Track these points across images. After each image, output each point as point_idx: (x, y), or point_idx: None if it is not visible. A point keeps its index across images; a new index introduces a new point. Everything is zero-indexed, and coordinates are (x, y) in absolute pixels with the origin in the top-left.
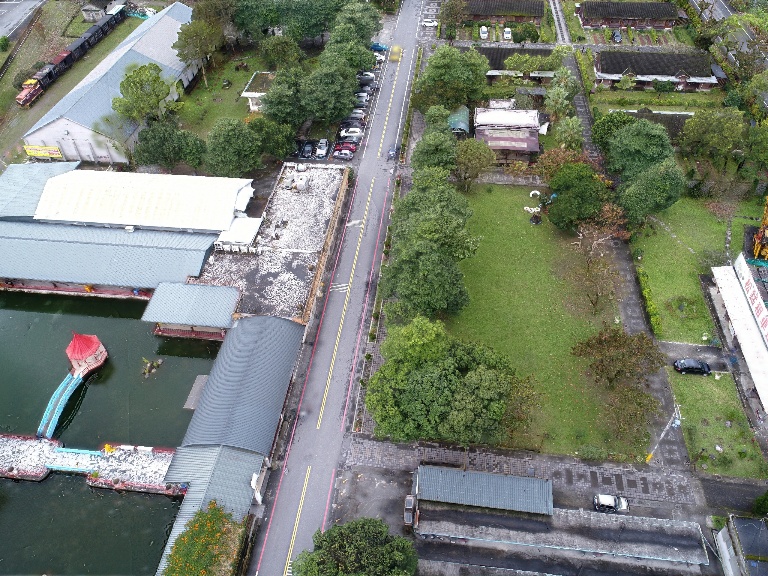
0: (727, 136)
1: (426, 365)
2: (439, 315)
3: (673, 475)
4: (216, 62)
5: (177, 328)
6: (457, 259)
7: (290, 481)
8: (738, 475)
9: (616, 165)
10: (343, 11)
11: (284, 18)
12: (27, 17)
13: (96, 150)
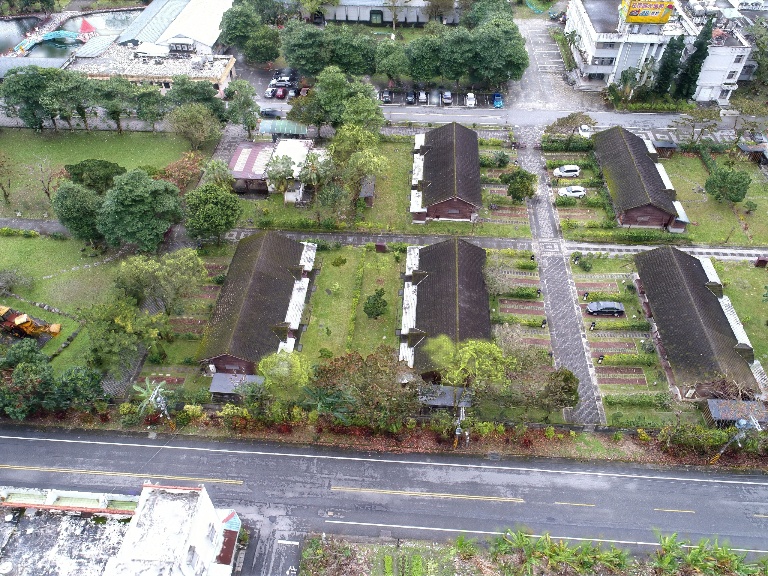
0: None
1: None
2: (54, 137)
3: None
4: None
5: None
6: None
7: None
8: None
9: None
10: None
11: (481, 22)
12: None
13: None
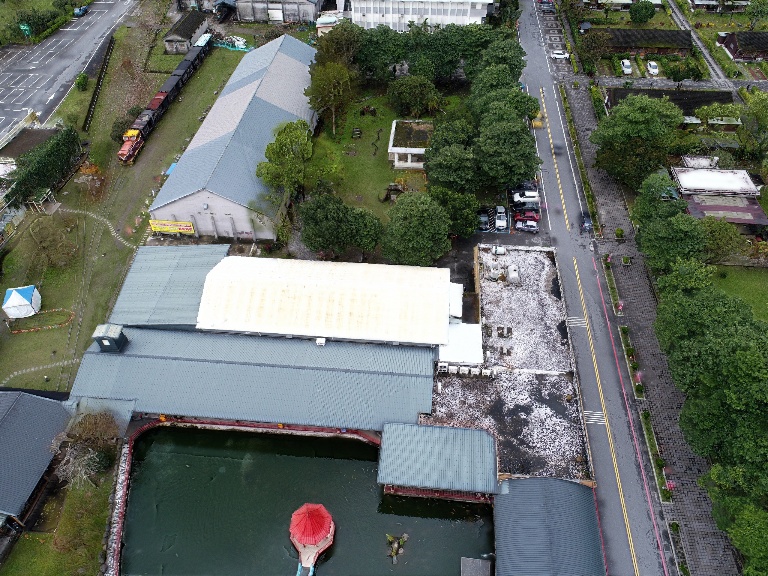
0: None
1: None
2: None
3: None
4: None
5: None
6: None
7: None
8: None
9: None
10: (492, 48)
11: (413, 54)
12: (99, 48)
13: (238, 225)
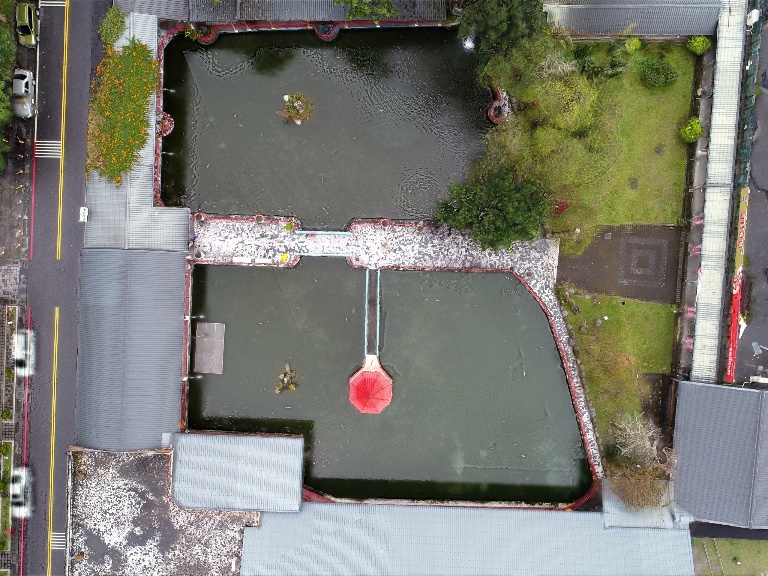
0: None
1: None
2: None
3: None
4: None
5: None
6: None
7: (76, 240)
8: None
9: None
10: None
11: None
12: None
13: None
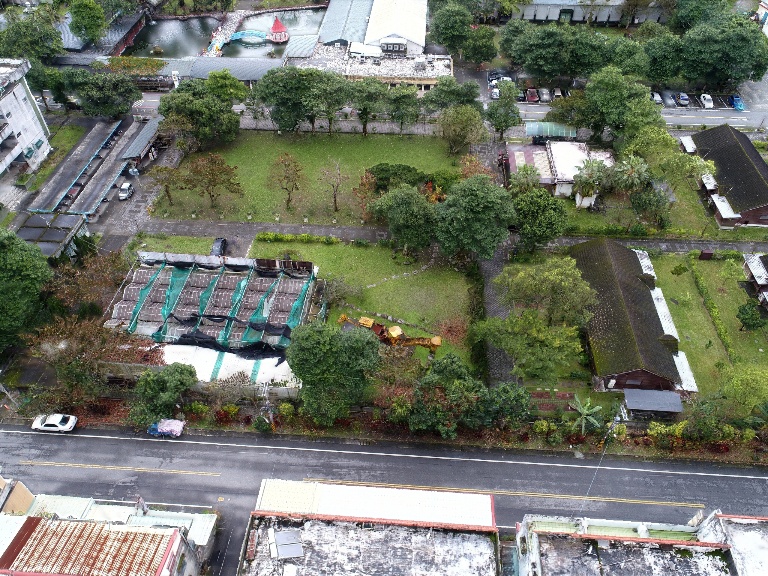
0: None
1: None
2: (297, 139)
3: None
4: None
5: None
6: None
7: None
8: None
9: None
10: None
11: (700, 21)
12: None
13: None
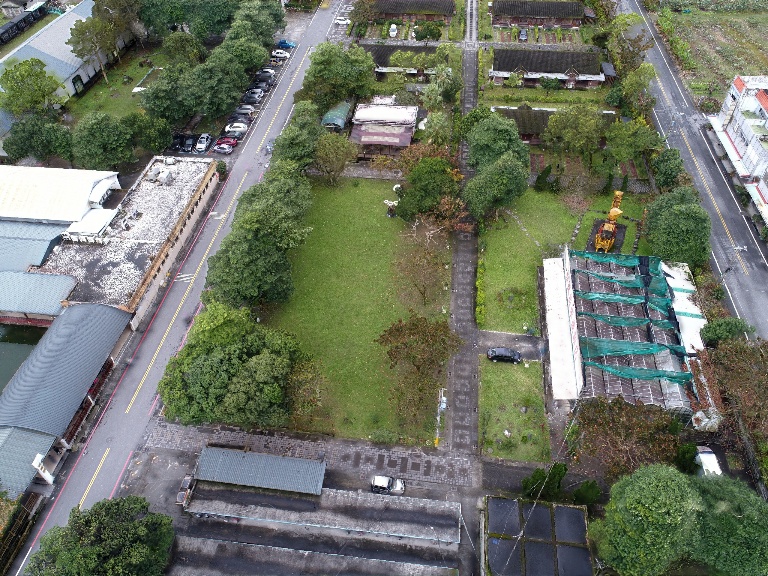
0: (581, 132)
1: (215, 350)
2: (274, 304)
3: (458, 458)
4: (124, 58)
5: (13, 315)
6: (280, 249)
7: (86, 462)
8: (520, 459)
9: (471, 159)
10: (241, 8)
11: (189, 15)
12: None
13: None
